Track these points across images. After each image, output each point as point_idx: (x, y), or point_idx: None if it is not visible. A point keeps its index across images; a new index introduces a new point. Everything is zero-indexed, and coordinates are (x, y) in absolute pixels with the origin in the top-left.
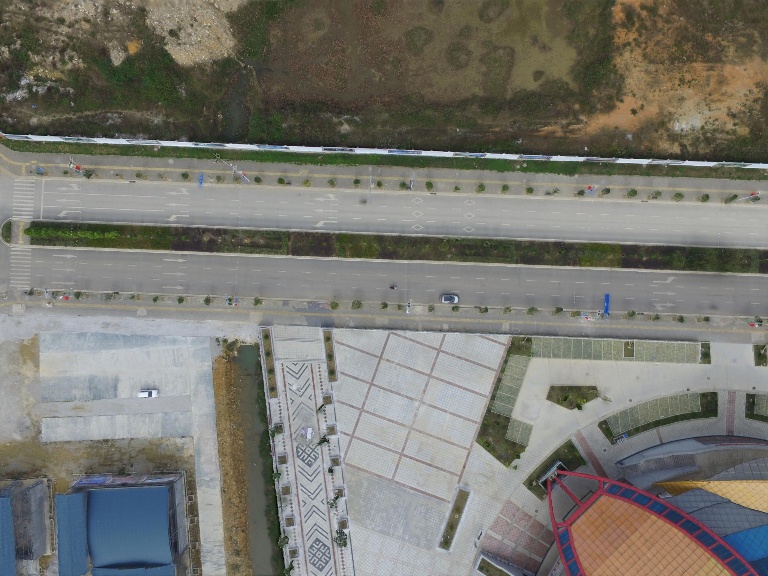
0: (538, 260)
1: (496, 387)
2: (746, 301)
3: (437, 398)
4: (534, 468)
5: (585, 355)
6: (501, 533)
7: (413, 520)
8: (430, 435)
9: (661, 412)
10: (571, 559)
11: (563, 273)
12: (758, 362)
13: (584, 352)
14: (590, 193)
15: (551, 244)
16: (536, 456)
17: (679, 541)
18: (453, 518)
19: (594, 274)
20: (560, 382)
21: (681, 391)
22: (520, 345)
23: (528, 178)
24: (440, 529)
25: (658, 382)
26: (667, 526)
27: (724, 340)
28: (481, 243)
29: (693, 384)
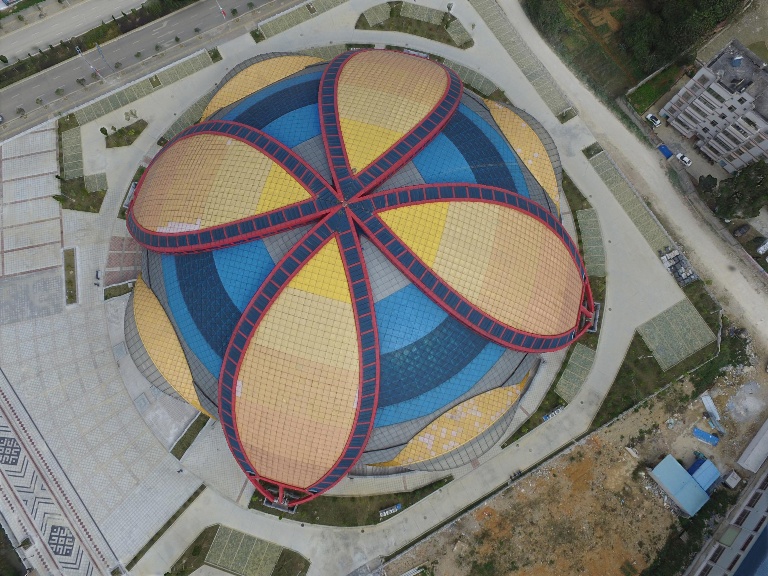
0: (54, 60)
1: (60, 161)
2: (229, 8)
3: (15, 195)
4: (121, 202)
5: (123, 103)
6: (117, 265)
7: (35, 297)
8: (21, 225)
9: (203, 110)
10: (131, 222)
11: (80, 60)
12: (257, 40)
13: (121, 101)
14: (75, 0)
15: (60, 46)
16: (119, 192)
17: (178, 145)
18: (68, 275)
19: (105, 49)
20: (112, 131)
21: (211, 88)
22: (66, 122)
23: (22, 14)
24: (63, 291)
25: (190, 91)
26: (173, 146)
27: (226, 40)
28: (2, 72)
29: (217, 79)
